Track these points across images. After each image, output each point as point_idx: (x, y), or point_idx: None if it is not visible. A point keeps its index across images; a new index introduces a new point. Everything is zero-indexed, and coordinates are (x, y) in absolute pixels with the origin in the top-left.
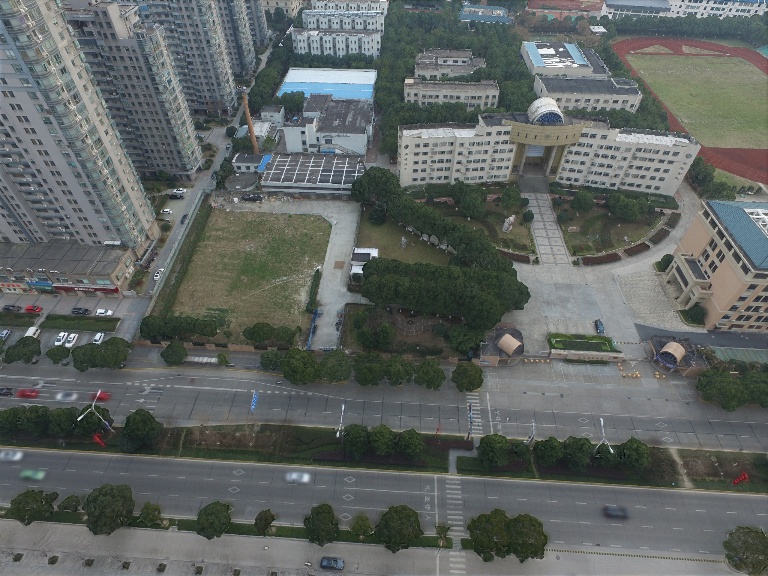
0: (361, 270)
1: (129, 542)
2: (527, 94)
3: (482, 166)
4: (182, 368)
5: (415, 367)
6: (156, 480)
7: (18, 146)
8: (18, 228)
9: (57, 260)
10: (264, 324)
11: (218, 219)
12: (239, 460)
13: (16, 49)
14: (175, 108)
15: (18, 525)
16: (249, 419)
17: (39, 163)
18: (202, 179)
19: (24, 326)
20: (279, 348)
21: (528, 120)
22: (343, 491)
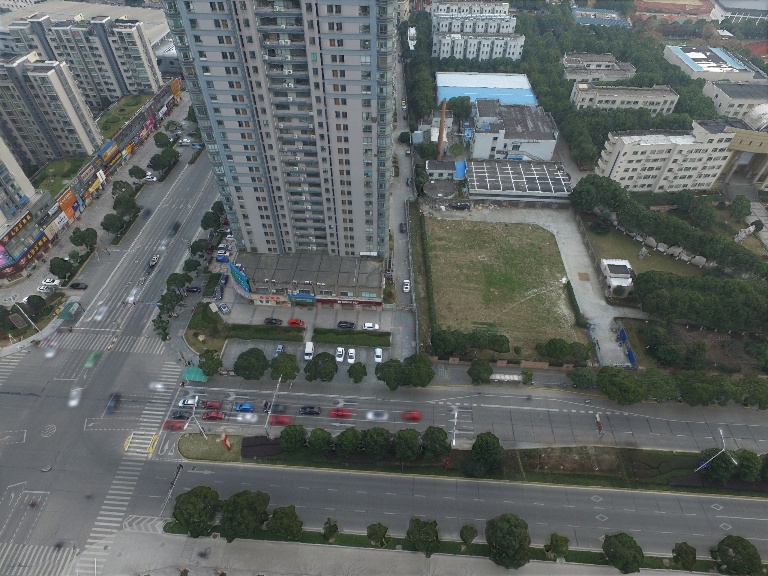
0: (622, 283)
1: (521, 575)
2: (706, 100)
3: (691, 174)
4: (480, 386)
5: (744, 387)
6: (515, 507)
7: (318, 155)
8: (273, 238)
9: (315, 272)
10: (563, 340)
11: (434, 228)
12: (591, 485)
13: (376, 55)
14: None
15: (395, 556)
16: (578, 441)
17: (333, 172)
18: (397, 186)
19: (296, 340)
20: (575, 365)
21: (747, 127)
22: (717, 520)
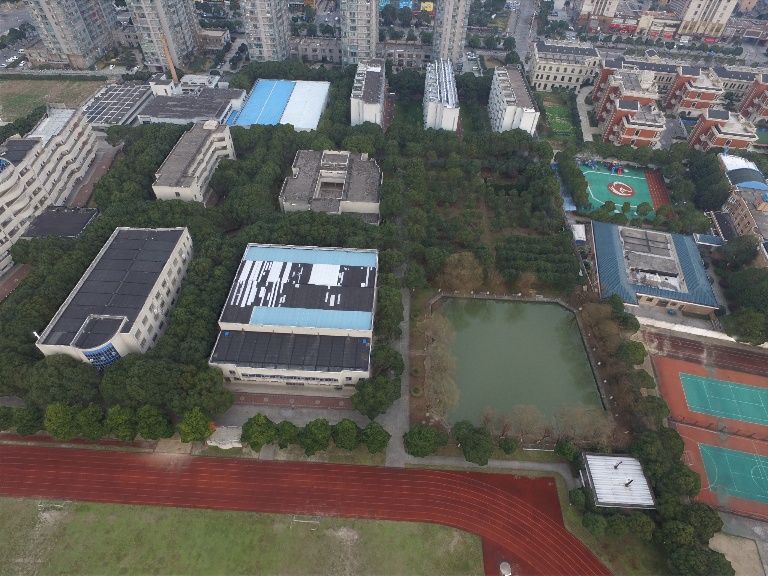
0: None
1: None
2: None
3: None
4: None
5: None
6: None
7: None
8: None
9: None
10: None
11: (92, 84)
12: None
13: None
14: (137, 14)
15: None
16: None
17: None
18: None
19: None
20: None
21: None
22: None
